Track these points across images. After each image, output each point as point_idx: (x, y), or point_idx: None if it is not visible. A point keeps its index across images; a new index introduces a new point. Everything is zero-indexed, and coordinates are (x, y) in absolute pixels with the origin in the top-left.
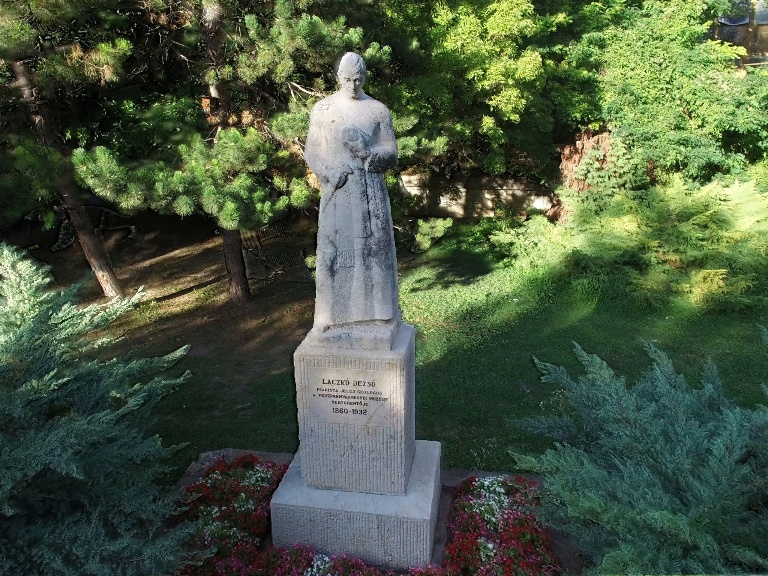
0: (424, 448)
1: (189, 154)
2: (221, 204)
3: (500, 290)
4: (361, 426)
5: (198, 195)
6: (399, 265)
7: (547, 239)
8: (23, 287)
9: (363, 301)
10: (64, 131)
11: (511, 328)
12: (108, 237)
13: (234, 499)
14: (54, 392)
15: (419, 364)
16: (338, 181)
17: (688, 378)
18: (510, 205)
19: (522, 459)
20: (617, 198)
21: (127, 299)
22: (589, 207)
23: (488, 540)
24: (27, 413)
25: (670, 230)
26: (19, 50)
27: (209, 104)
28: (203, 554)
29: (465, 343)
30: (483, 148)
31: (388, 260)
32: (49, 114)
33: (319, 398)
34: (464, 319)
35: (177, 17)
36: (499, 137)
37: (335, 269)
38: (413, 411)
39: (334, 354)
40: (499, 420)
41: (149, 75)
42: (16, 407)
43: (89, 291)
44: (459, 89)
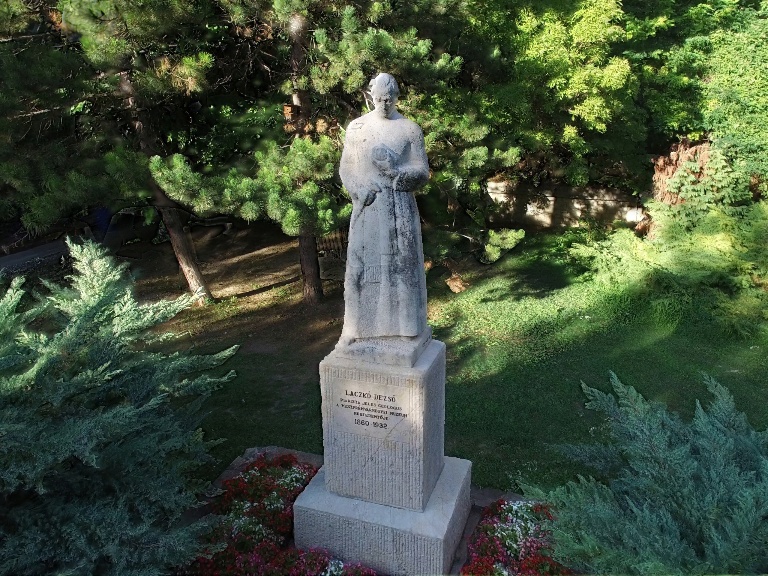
0: (452, 465)
1: (264, 160)
2: (284, 211)
3: (574, 305)
4: (381, 439)
5: (264, 201)
6: (474, 273)
7: (632, 254)
8: (95, 283)
9: (388, 316)
10: (166, 134)
11: (578, 346)
12: (205, 233)
13: (266, 496)
14: (112, 381)
15: (475, 377)
16: (365, 199)
17: (764, 415)
18: (600, 216)
19: (529, 490)
20: (712, 214)
21: (186, 298)
22: (680, 222)
23: (506, 566)
24: (83, 399)
25: (767, 251)
26: (116, 63)
27: (290, 112)
28: (214, 547)
29: (526, 359)
30: (565, 158)
31: (413, 277)
32: (147, 120)
33: (342, 408)
34: (530, 333)
35: (262, 30)
36: (583, 147)
37: (361, 284)
38: (440, 428)
39: (356, 367)
40: (546, 442)
41: (232, 85)
42: (58, 396)
43: (179, 284)
44: (540, 98)
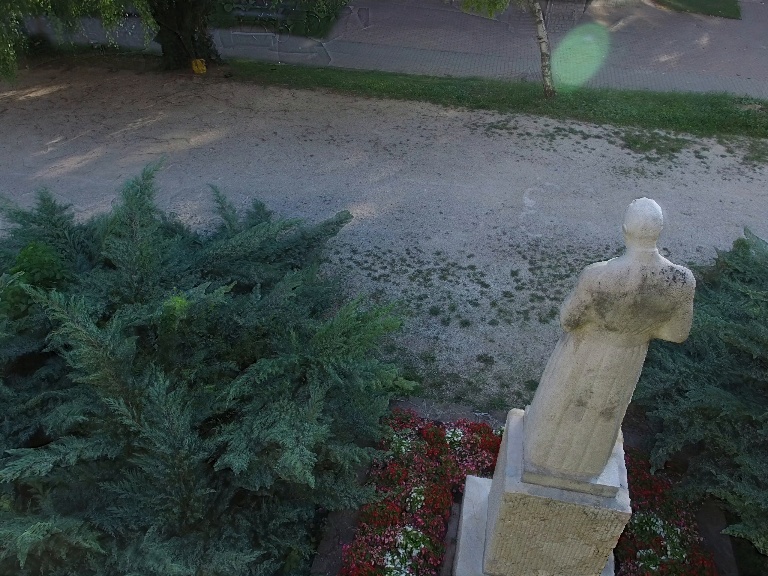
0: (474, 572)
1: None
2: None
3: None
4: None
5: None
6: None
7: None
8: None
9: None
10: None
11: None
12: None
13: (661, 567)
14: None
15: None
16: None
17: None
18: None
19: None
20: None
21: None
22: None
23: None
24: None
25: None
26: None
27: None
28: None
29: None
30: None
31: None
32: None
33: None
34: None
35: None
36: None
37: None
38: None
39: None
40: None
41: None
42: None
43: None
44: None
